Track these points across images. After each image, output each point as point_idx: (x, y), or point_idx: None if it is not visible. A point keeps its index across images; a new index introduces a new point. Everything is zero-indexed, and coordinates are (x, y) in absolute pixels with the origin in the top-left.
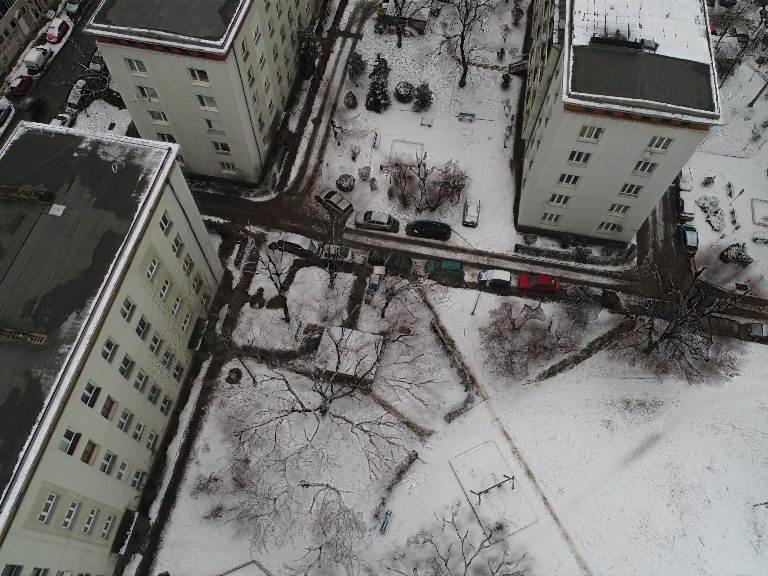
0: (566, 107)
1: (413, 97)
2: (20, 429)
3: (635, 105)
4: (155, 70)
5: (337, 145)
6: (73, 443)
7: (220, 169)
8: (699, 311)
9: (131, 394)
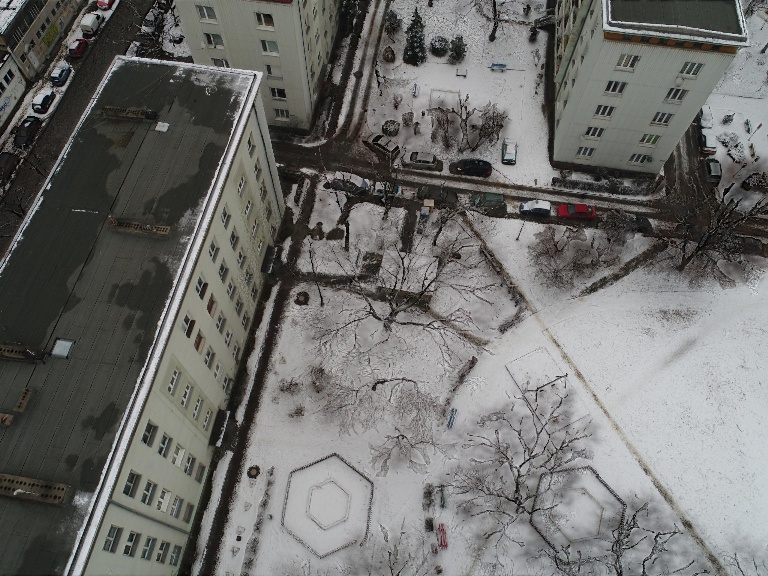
0: (606, 36)
1: (447, 51)
2: (155, 303)
3: (670, 31)
4: (224, 16)
5: (381, 94)
6: (189, 328)
7: (274, 117)
8: None
9: (225, 299)
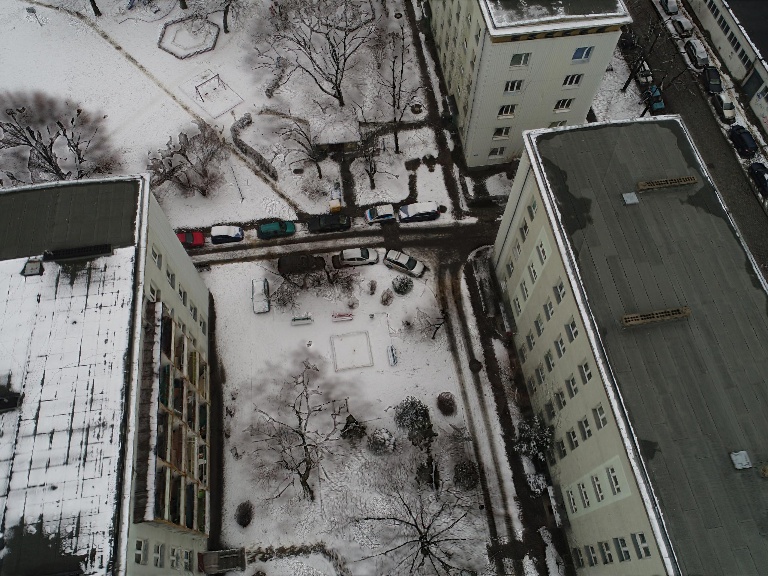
0: None
1: None
2: None
3: None
4: None
5: None
6: None
7: None
8: None
9: None
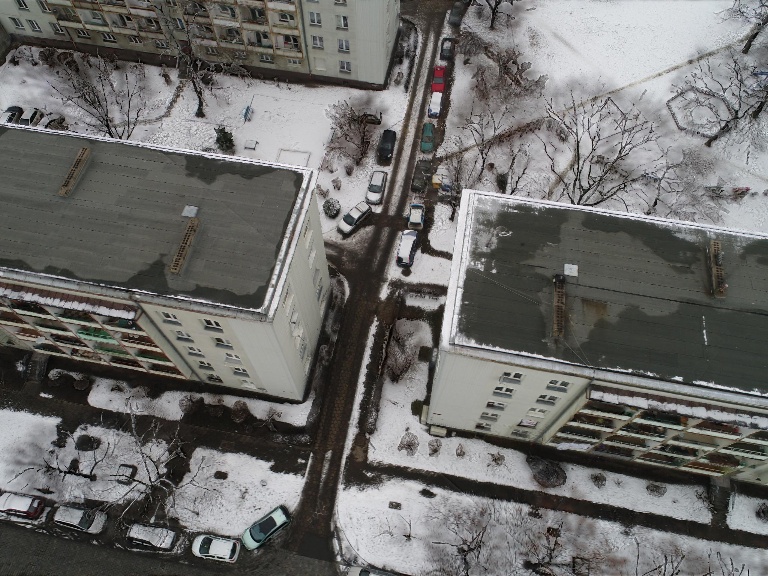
0: None
1: None
2: None
3: None
4: (294, 278)
5: None
6: None
7: None
8: (453, 0)
9: None
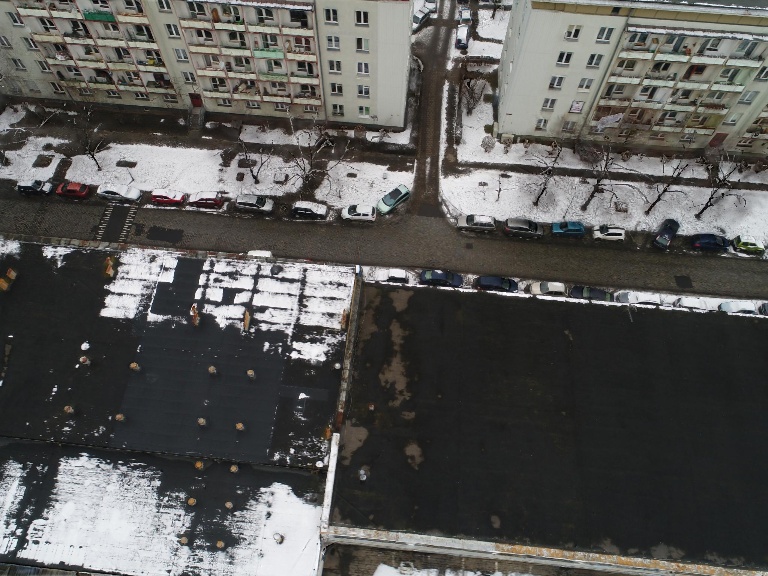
0: None
1: None
2: None
3: None
4: None
5: None
6: None
7: None
8: None
9: None
